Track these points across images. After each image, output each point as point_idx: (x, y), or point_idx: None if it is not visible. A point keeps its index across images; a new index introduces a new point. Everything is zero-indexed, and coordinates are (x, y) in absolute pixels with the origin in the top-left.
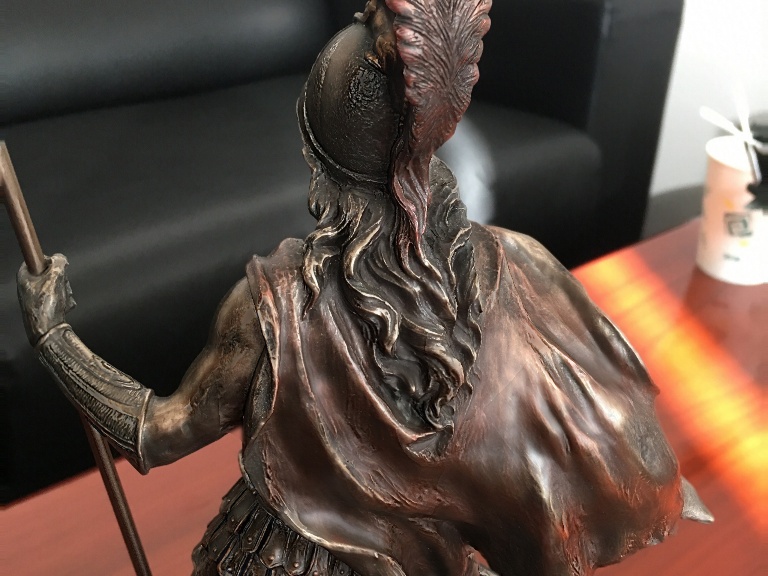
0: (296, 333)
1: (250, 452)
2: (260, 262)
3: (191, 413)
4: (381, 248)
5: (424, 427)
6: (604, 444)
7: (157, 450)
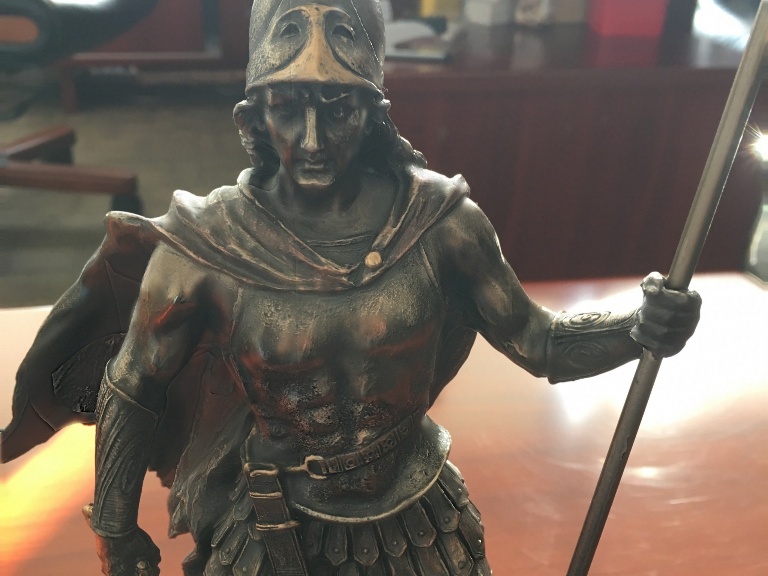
0: None
1: None
2: (454, 179)
3: None
4: None
5: None
6: None
7: None
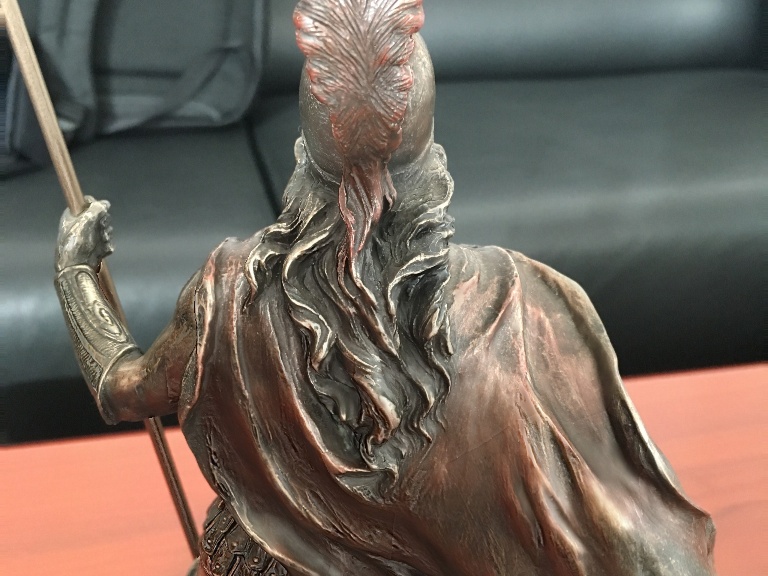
0: (232, 325)
1: (192, 432)
2: (223, 245)
3: (145, 378)
4: (327, 257)
5: (360, 462)
6: (588, 550)
7: (117, 404)
